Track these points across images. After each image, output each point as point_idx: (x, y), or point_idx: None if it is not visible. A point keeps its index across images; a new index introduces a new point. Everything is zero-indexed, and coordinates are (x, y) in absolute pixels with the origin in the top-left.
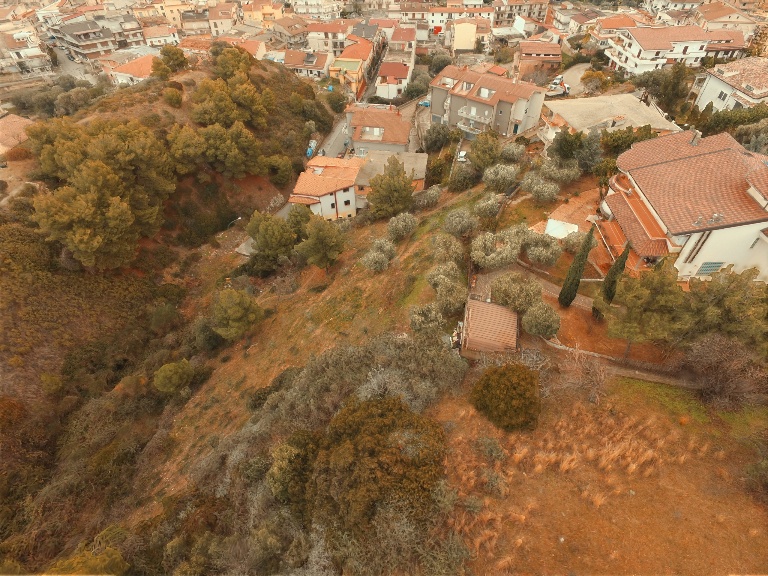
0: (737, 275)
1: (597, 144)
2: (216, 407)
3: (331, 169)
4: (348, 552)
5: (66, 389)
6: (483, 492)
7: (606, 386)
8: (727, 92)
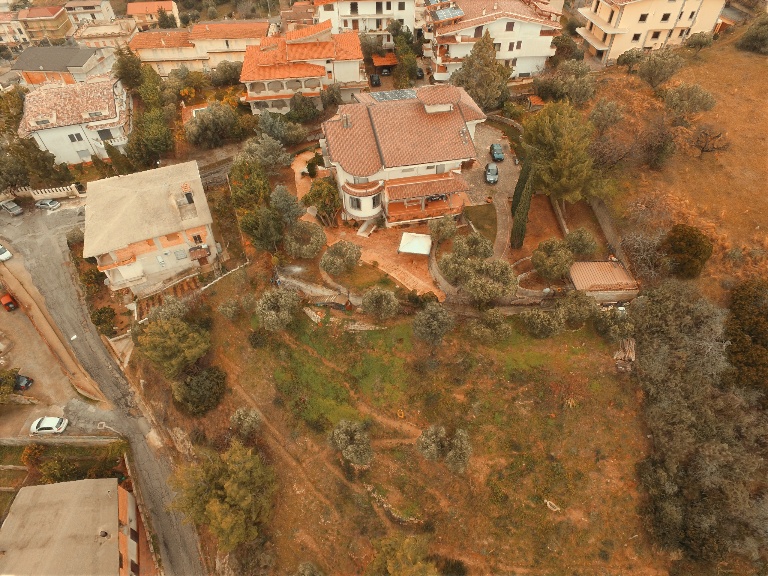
0: (548, 127)
1: None
2: None
3: None
4: None
5: None
6: (762, 261)
7: (617, 215)
8: (77, 132)
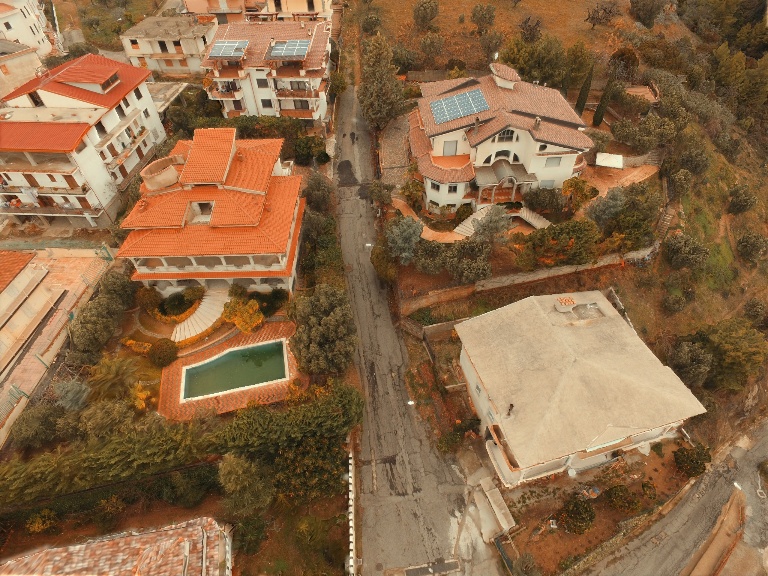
0: None
1: (605, 202)
2: None
3: None
4: None
5: None
6: None
7: None
8: None
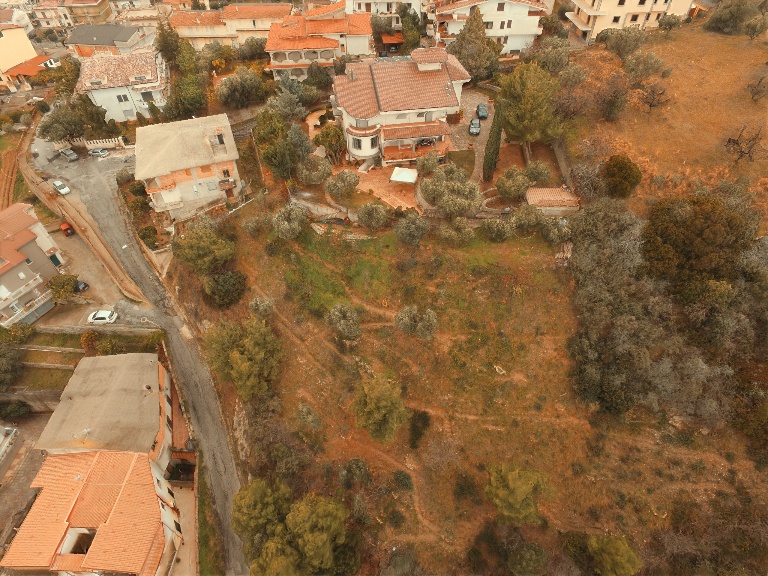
0: (518, 81)
1: None
2: (618, 483)
3: (80, 510)
4: (753, 229)
5: None
6: None
7: (572, 155)
8: (124, 93)
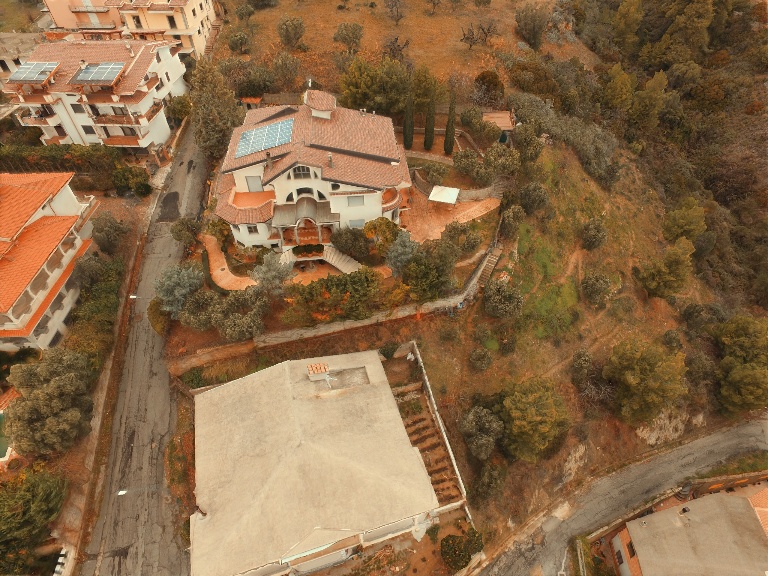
0: None
1: None
2: None
3: None
4: None
5: (760, 223)
6: None
7: None
8: None
